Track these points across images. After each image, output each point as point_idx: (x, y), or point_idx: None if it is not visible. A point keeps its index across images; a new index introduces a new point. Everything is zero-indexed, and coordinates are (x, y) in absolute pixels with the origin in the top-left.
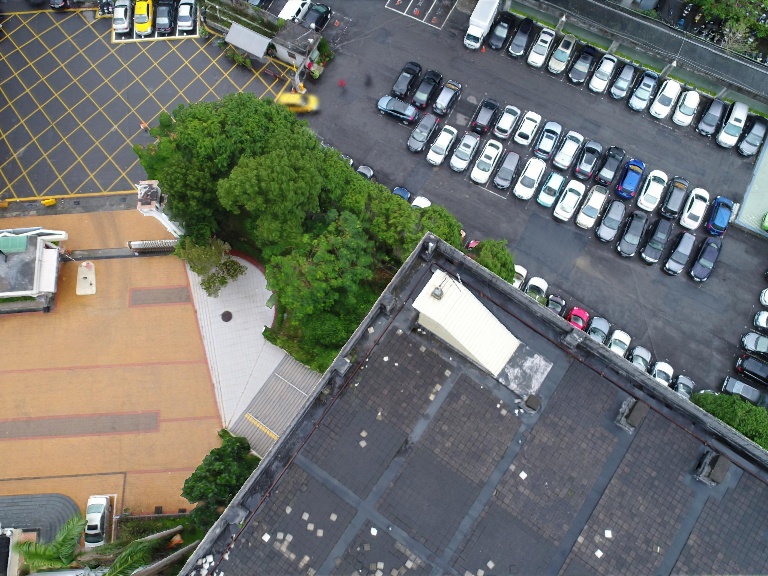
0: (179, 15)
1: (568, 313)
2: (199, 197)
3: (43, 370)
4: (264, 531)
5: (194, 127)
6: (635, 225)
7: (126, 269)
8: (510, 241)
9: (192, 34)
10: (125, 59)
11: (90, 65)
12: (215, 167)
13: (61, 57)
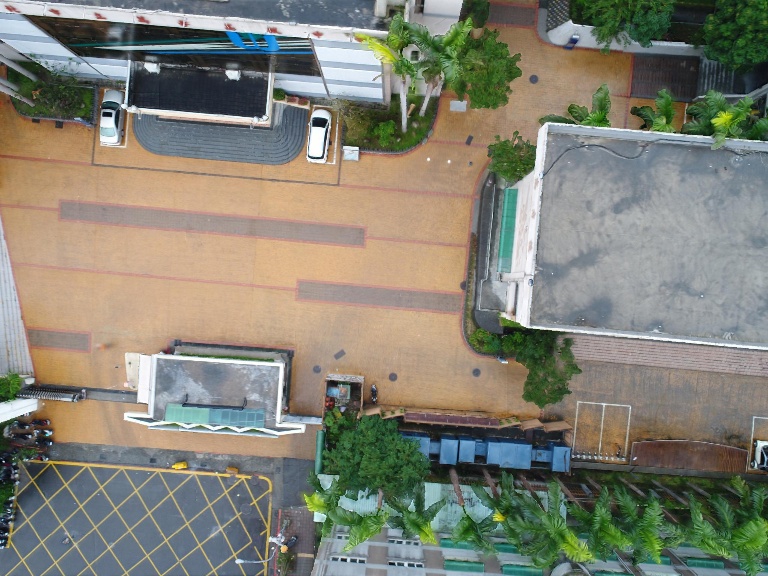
0: None
1: None
2: None
3: (176, 278)
4: None
5: None
6: None
7: (95, 375)
8: None
9: None
10: None
11: None
12: None
13: None
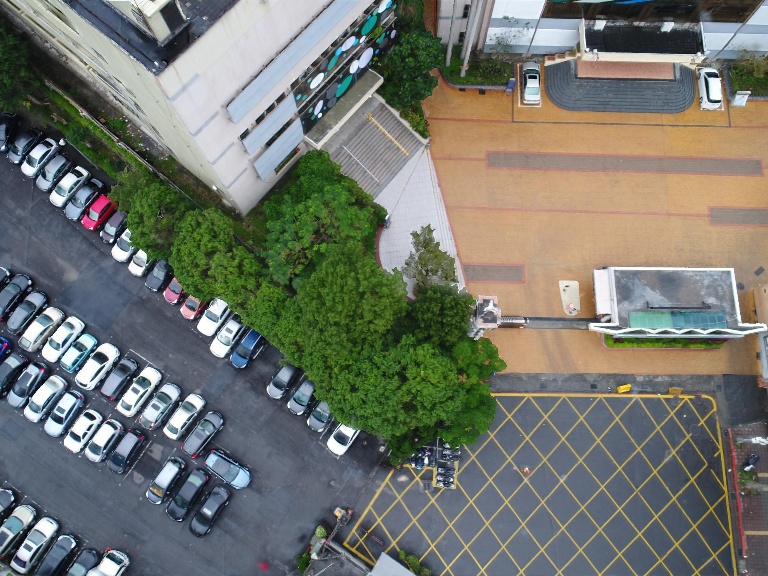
0: None
1: (101, 228)
2: None
3: (599, 212)
4: None
5: (435, 372)
6: (4, 301)
7: (531, 304)
8: (138, 303)
9: None
10: None
11: None
12: None
13: None
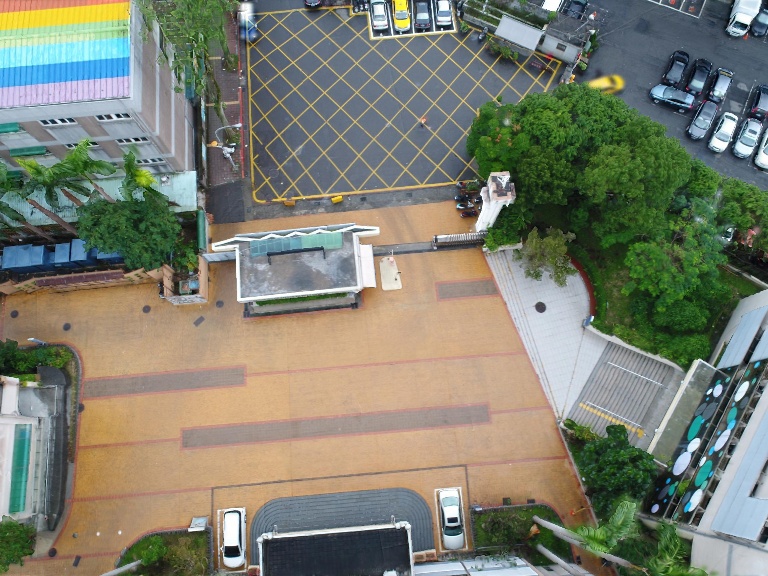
0: (439, 10)
1: None
2: (562, 186)
3: (364, 366)
4: None
5: (548, 117)
6: None
7: (427, 263)
8: None
9: (449, 29)
10: (387, 55)
11: (353, 62)
12: (564, 157)
13: (322, 55)
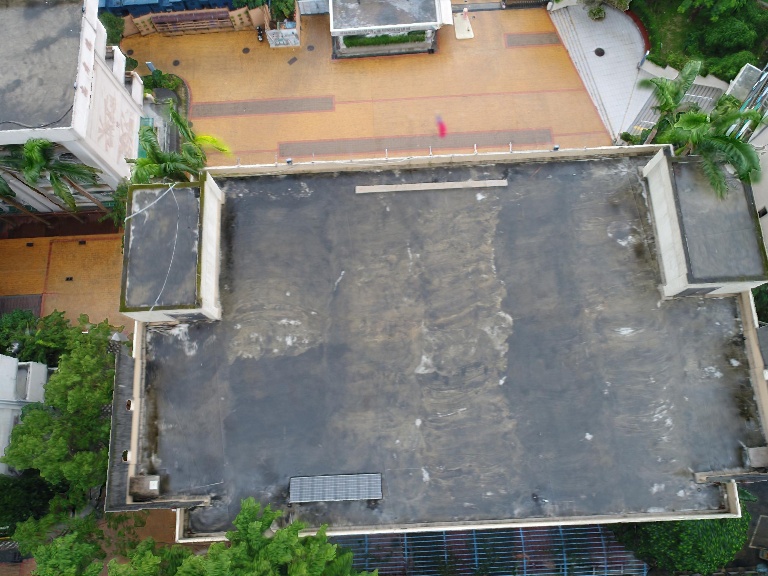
0: None
1: None
2: None
3: (440, 97)
4: None
5: None
6: None
7: (496, 19)
8: None
9: None
10: None
11: None
12: None
13: None
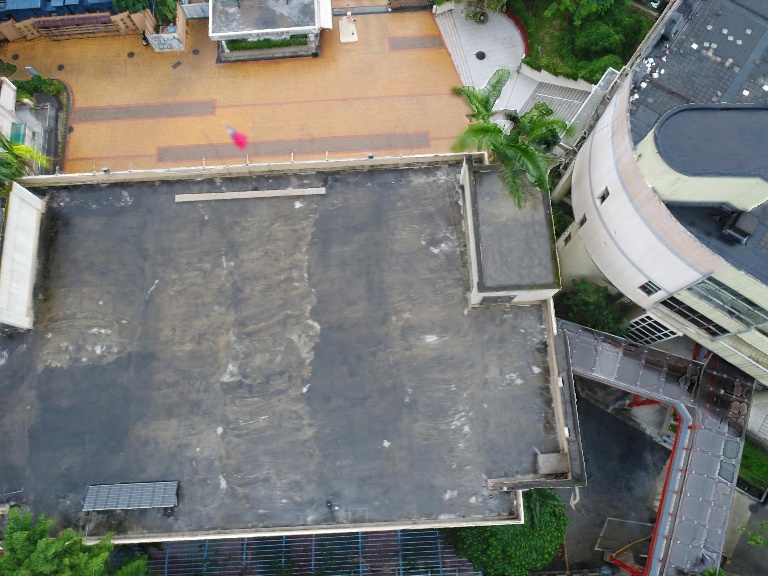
0: None
1: None
2: None
3: (320, 101)
4: (692, 42)
5: None
6: None
7: (382, 22)
8: None
9: None
10: None
11: None
12: None
13: None
